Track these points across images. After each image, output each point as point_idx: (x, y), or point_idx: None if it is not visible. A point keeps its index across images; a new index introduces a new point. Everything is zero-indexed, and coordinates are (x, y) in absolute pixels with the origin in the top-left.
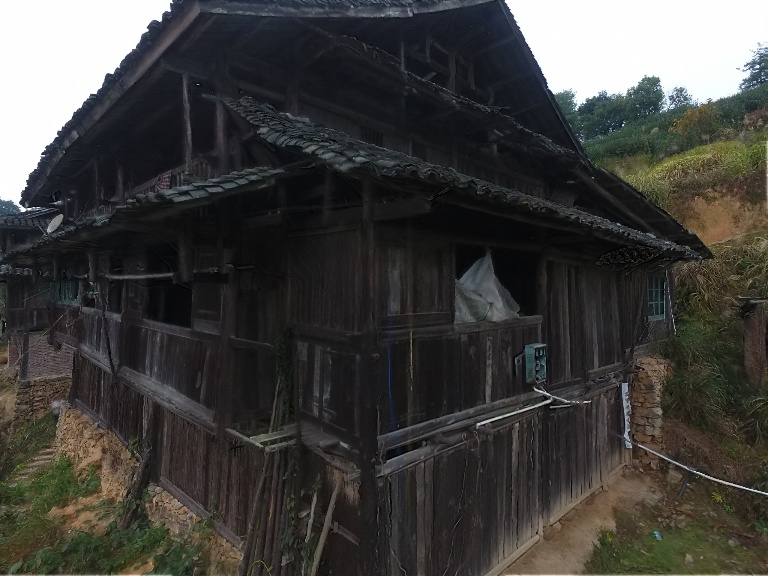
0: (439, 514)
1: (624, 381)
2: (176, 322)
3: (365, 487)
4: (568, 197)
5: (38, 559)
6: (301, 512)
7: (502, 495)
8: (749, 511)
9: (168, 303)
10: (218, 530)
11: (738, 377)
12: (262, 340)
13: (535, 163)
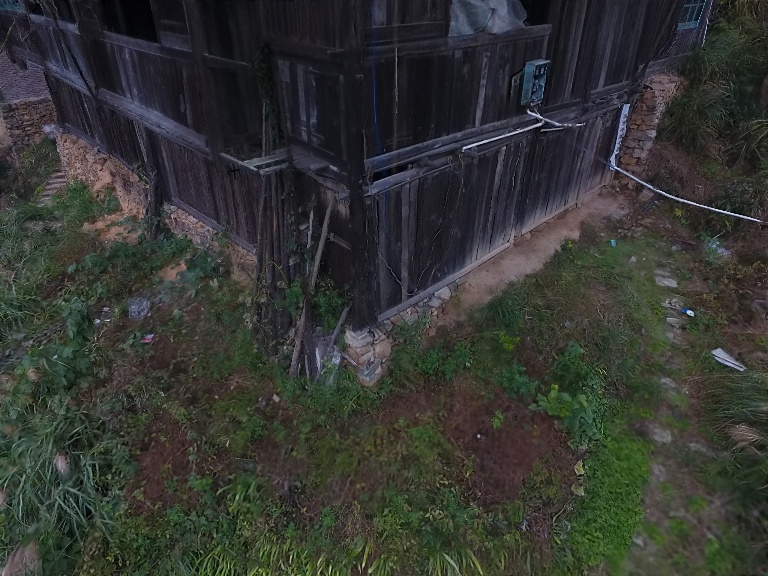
0: (422, 226)
1: (627, 102)
2: (141, 35)
3: (354, 205)
4: None
5: (88, 262)
6: (301, 225)
7: (481, 211)
8: (701, 224)
9: (125, 10)
10: (233, 240)
11: (750, 97)
12: (239, 58)
13: None
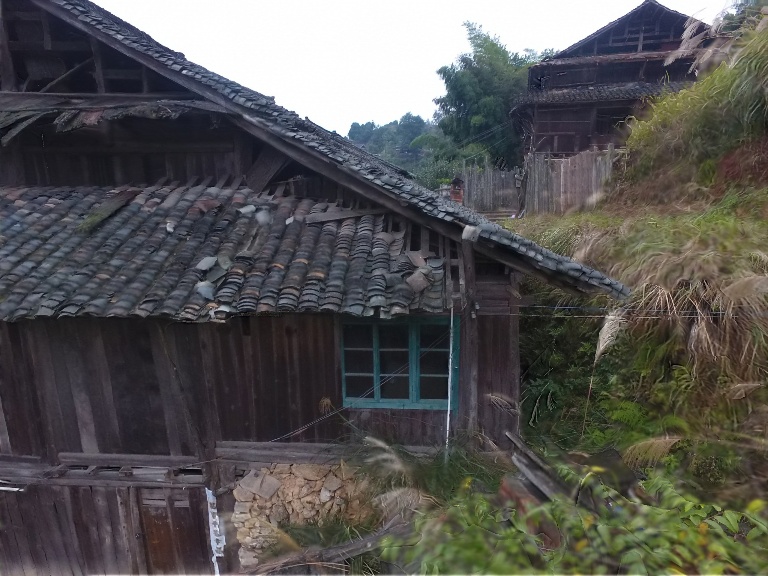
0: None
1: (208, 486)
2: None
3: None
4: (273, 164)
5: None
6: None
7: None
8: None
9: None
10: None
11: None
12: None
13: (169, 126)
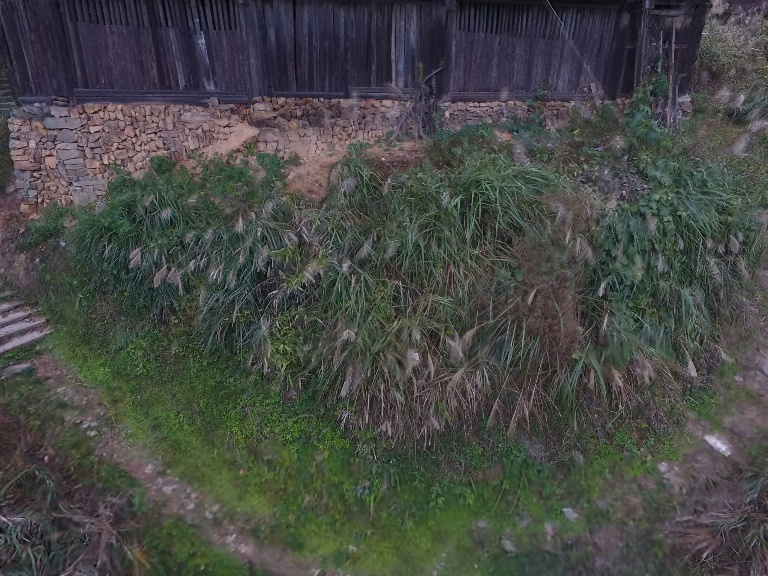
0: None
1: None
2: None
3: None
4: None
5: (464, 142)
6: None
7: None
8: None
9: None
10: (546, 98)
11: None
12: None
13: None
